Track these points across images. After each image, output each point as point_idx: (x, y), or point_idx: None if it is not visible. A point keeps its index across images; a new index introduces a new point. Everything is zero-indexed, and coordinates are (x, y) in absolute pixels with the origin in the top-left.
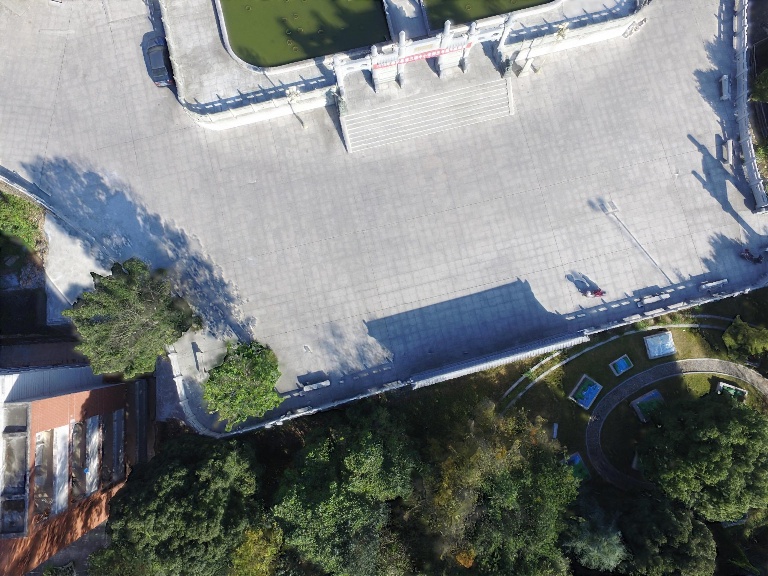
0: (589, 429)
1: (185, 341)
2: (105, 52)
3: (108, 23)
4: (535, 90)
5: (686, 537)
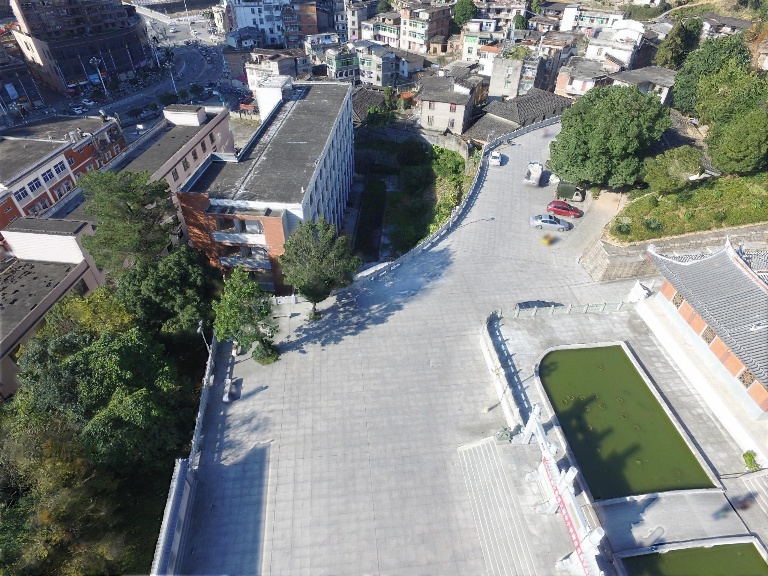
0: None
1: (303, 309)
2: (543, 282)
3: (568, 285)
4: None
5: None
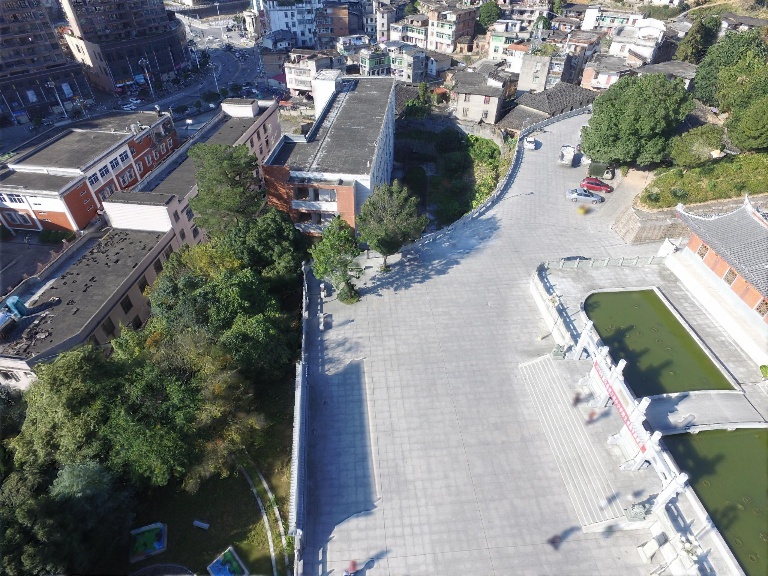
0: (184, 572)
1: (374, 263)
2: (581, 244)
3: (603, 246)
4: (624, 569)
5: (28, 558)
